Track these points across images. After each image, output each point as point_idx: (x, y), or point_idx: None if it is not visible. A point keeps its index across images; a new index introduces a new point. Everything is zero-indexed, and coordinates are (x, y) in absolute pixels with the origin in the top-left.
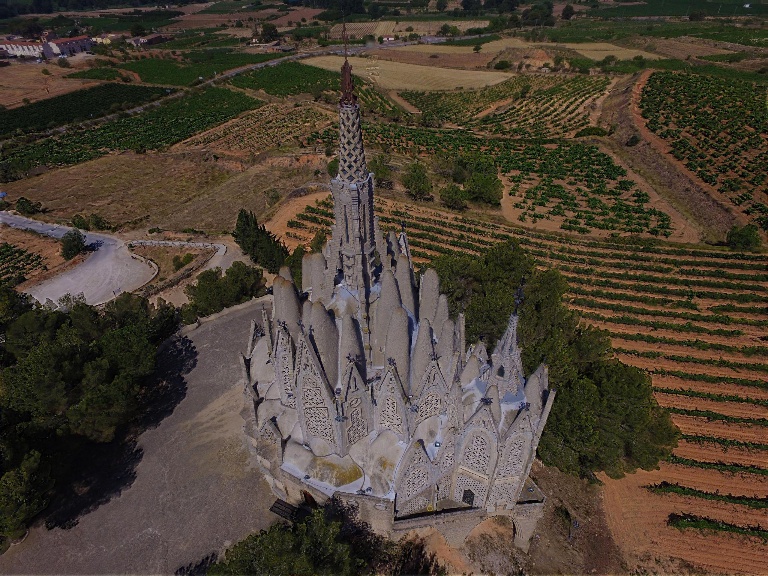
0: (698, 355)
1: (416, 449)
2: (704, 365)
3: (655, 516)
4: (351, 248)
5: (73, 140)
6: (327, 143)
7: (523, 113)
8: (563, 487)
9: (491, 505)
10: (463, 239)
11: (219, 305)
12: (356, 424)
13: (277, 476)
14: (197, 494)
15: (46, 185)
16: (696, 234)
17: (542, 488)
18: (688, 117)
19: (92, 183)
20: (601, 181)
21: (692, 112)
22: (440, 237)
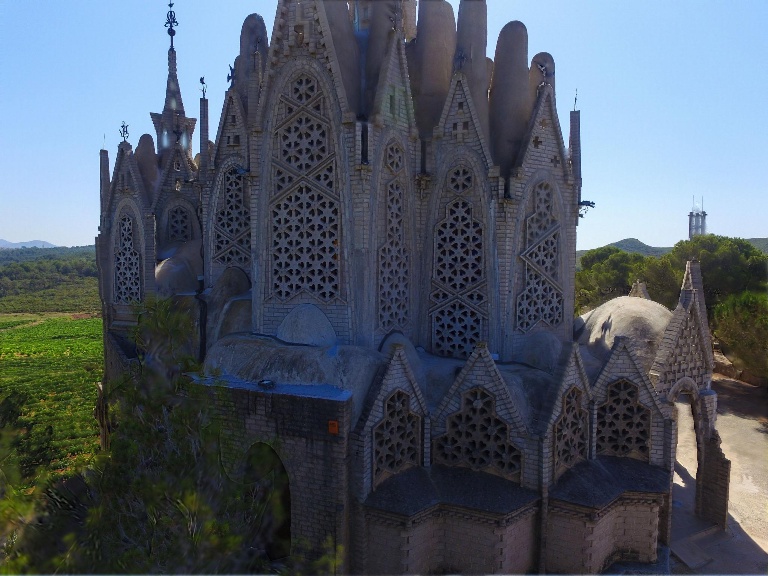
0: None
1: None
2: None
3: None
4: None
5: None
6: None
7: None
8: None
9: None
10: None
11: None
12: None
13: None
14: None
15: None
16: None
17: None
18: None
19: None
20: None
21: None
22: None
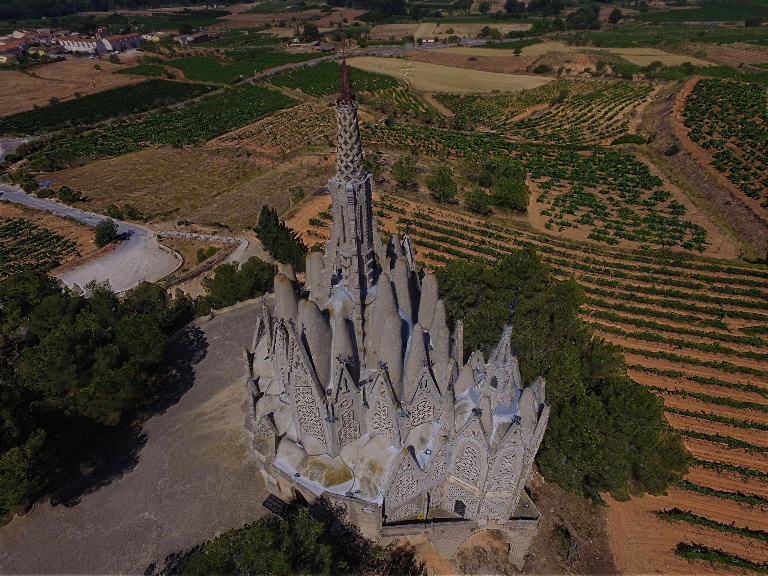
0: (724, 378)
1: (404, 455)
2: (730, 388)
3: (662, 544)
4: (348, 249)
5: (117, 133)
6: None
7: (559, 118)
8: (565, 505)
9: (483, 518)
10: (484, 244)
11: (233, 299)
12: (347, 426)
13: (271, 471)
14: (194, 483)
15: (88, 175)
16: (734, 250)
17: (543, 505)
18: (734, 127)
19: (130, 175)
20: (635, 191)
21: (739, 122)
22: (461, 241)
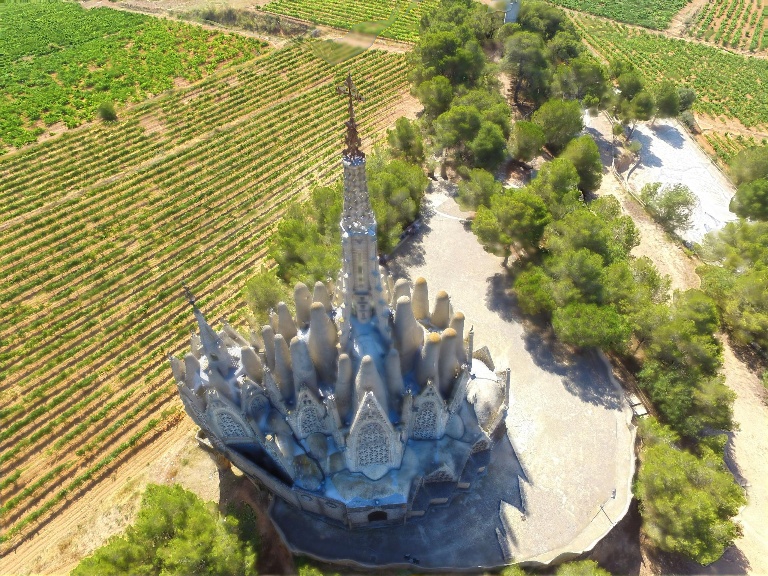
0: None
1: None
2: None
3: None
4: None
5: None
6: None
7: None
8: None
9: None
10: None
11: None
12: None
13: None
14: None
15: None
16: None
17: None
18: None
19: None
20: None
21: None
22: None
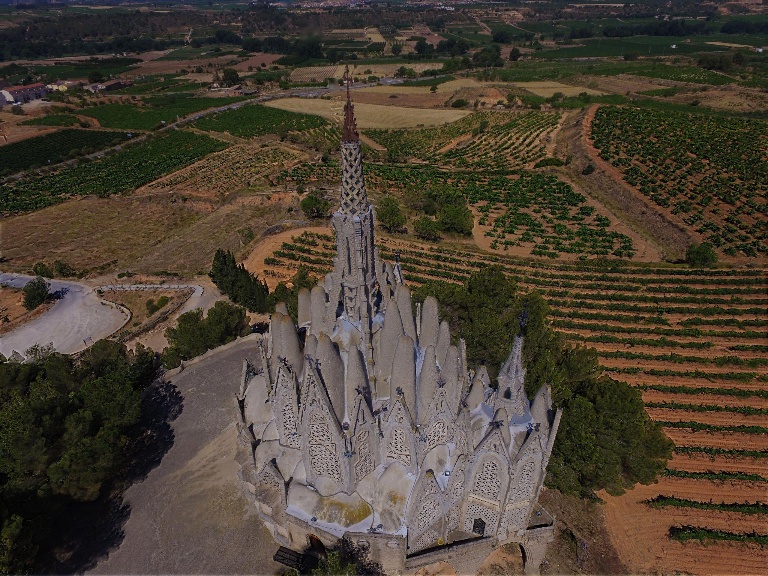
0: (675, 368)
1: (428, 479)
2: (682, 377)
3: (656, 531)
4: (353, 279)
5: (30, 187)
6: (297, 181)
7: (483, 147)
8: (565, 509)
9: (502, 533)
10: (440, 268)
11: (203, 347)
12: (363, 459)
13: (280, 522)
14: (193, 549)
15: (2, 234)
16: (657, 254)
17: None
18: (636, 146)
19: (53, 229)
20: (564, 208)
21: (639, 142)
22: (418, 267)
